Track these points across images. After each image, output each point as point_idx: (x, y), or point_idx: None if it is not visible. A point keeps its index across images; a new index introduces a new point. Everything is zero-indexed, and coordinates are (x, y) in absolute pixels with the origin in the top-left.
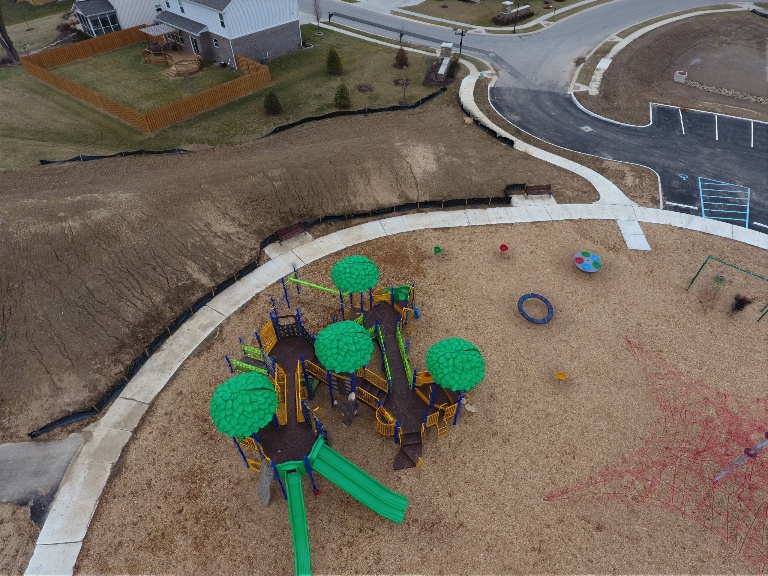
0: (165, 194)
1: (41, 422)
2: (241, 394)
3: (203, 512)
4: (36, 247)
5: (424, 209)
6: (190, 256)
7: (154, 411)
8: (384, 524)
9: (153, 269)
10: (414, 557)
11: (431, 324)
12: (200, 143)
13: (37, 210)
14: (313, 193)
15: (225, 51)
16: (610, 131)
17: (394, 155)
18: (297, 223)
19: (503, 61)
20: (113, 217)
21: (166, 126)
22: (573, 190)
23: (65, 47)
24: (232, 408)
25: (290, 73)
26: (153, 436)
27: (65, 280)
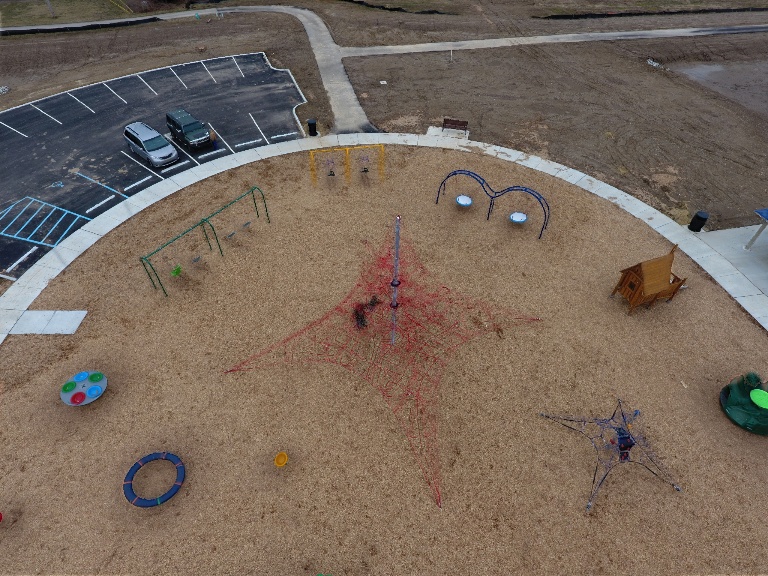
0: None
1: None
2: None
3: None
4: None
5: None
6: None
7: None
8: None
9: None
10: None
11: None
12: None
13: None
14: None
15: None
16: None
17: None
18: None
19: None
20: None
21: None
22: None
23: None
24: None
25: None
26: None
27: None
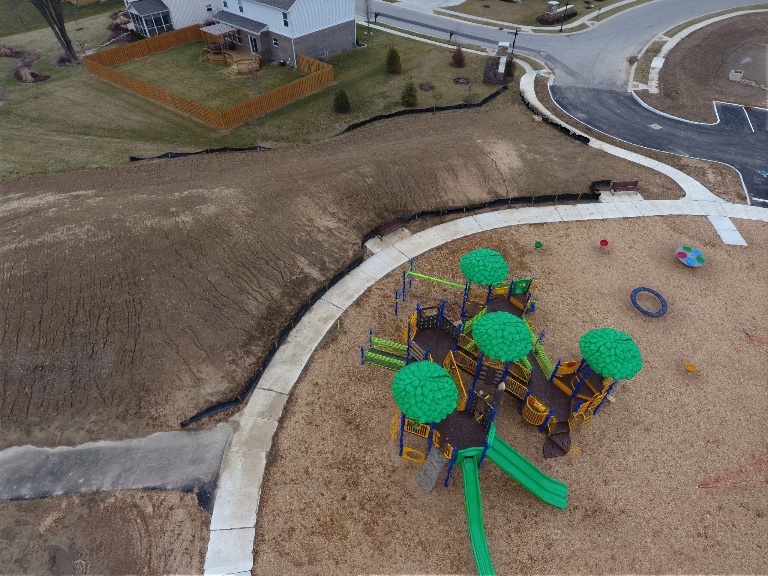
0: (266, 190)
1: (188, 412)
2: (428, 381)
3: (366, 499)
4: (155, 241)
5: (514, 205)
6: (299, 251)
7: (295, 401)
8: (547, 511)
9: (266, 263)
10: (584, 542)
11: (548, 317)
12: (276, 140)
13: (149, 205)
14: (405, 189)
15: (285, 50)
16: (679, 129)
17: (478, 152)
18: (396, 218)
19: (556, 60)
20: (222, 212)
21: (239, 124)
22: (657, 186)
23: (124, 46)
24: (422, 395)
25: (350, 72)
26: (300, 425)
27: (187, 273)
